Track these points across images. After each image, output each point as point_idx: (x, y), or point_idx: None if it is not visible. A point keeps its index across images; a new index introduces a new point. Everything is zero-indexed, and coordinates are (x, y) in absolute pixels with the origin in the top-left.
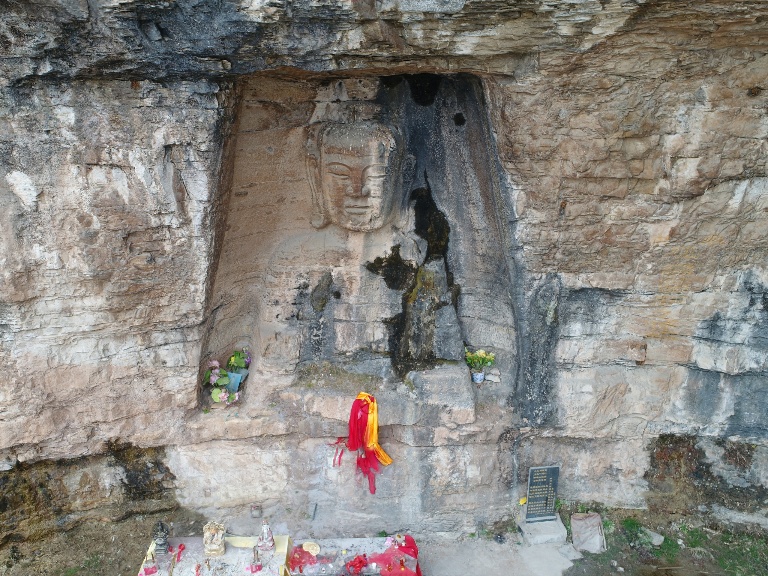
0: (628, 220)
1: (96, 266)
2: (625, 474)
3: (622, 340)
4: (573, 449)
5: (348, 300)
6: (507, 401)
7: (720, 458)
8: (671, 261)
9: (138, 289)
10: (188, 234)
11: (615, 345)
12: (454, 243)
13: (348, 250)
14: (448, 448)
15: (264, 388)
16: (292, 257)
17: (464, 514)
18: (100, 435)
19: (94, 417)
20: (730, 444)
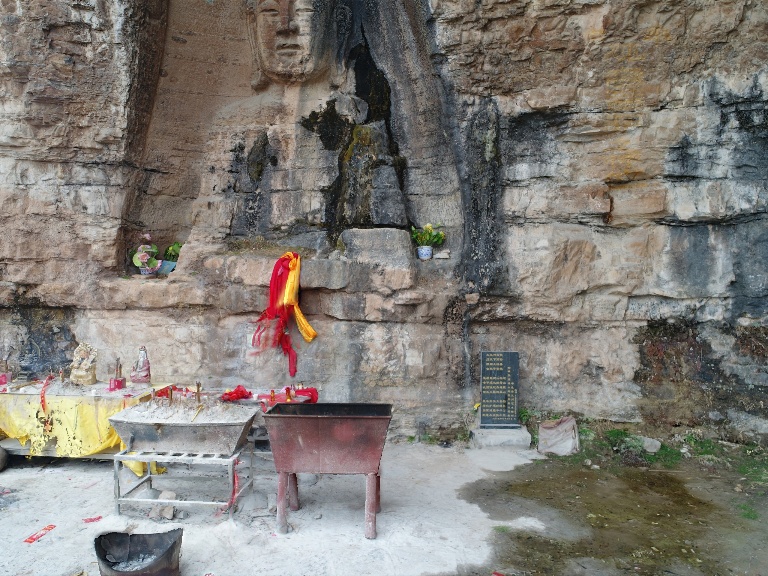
0: (553, 10)
1: (14, 55)
2: (608, 375)
3: (580, 186)
4: (539, 340)
5: (285, 166)
6: (454, 272)
7: (730, 349)
8: (614, 65)
9: (56, 95)
10: (109, 40)
11: (573, 194)
12: (396, 106)
13: (283, 104)
14: (384, 326)
15: (188, 255)
16: (229, 116)
17: (403, 414)
18: (8, 281)
19: (2, 252)
20: (740, 328)
